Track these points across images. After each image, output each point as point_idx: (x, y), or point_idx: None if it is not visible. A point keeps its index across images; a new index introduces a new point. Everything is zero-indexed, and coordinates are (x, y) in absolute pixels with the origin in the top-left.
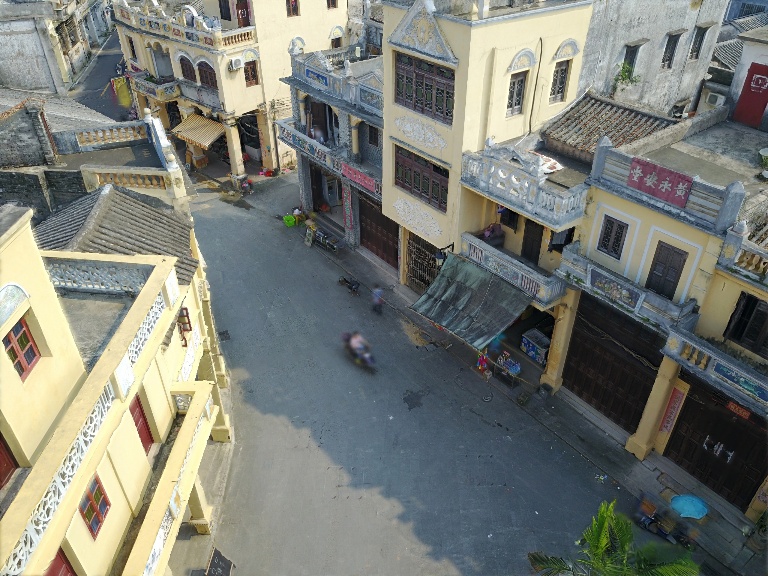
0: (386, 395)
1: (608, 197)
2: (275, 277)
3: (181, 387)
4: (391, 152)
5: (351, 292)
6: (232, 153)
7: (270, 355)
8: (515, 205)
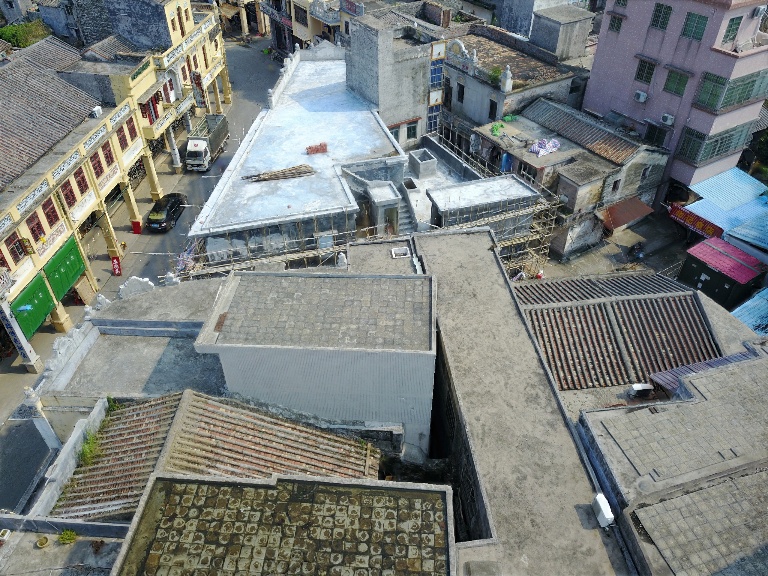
0: None
1: (344, 14)
2: (255, 68)
3: (215, 56)
4: (293, 7)
5: None
6: (242, 21)
7: (248, 87)
8: (321, 19)
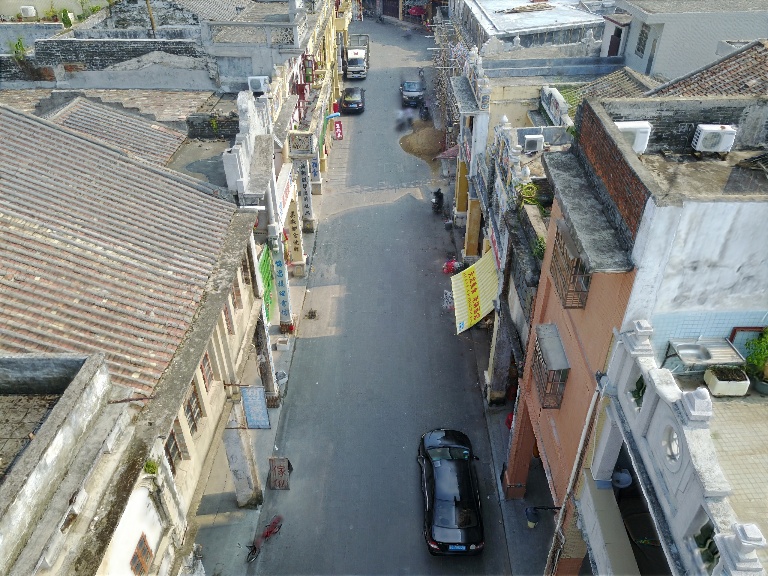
0: (396, 36)
1: None
2: None
3: None
4: None
5: (381, 23)
6: None
7: None
8: None
